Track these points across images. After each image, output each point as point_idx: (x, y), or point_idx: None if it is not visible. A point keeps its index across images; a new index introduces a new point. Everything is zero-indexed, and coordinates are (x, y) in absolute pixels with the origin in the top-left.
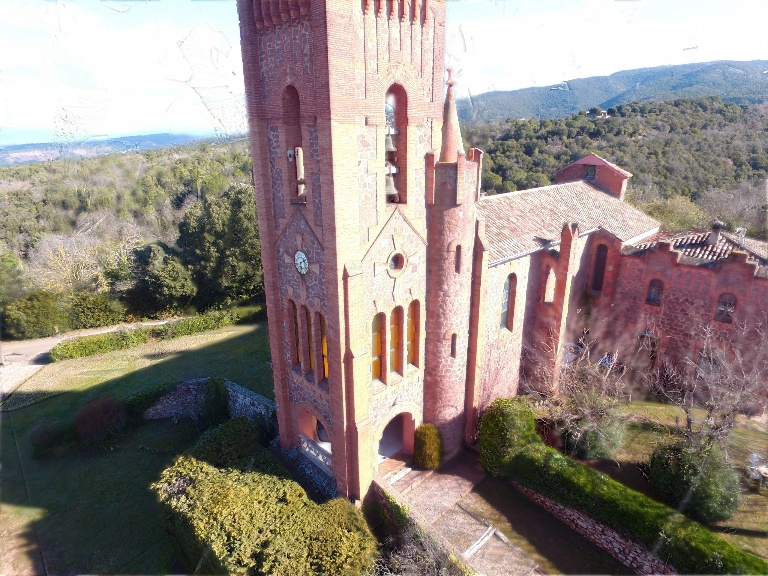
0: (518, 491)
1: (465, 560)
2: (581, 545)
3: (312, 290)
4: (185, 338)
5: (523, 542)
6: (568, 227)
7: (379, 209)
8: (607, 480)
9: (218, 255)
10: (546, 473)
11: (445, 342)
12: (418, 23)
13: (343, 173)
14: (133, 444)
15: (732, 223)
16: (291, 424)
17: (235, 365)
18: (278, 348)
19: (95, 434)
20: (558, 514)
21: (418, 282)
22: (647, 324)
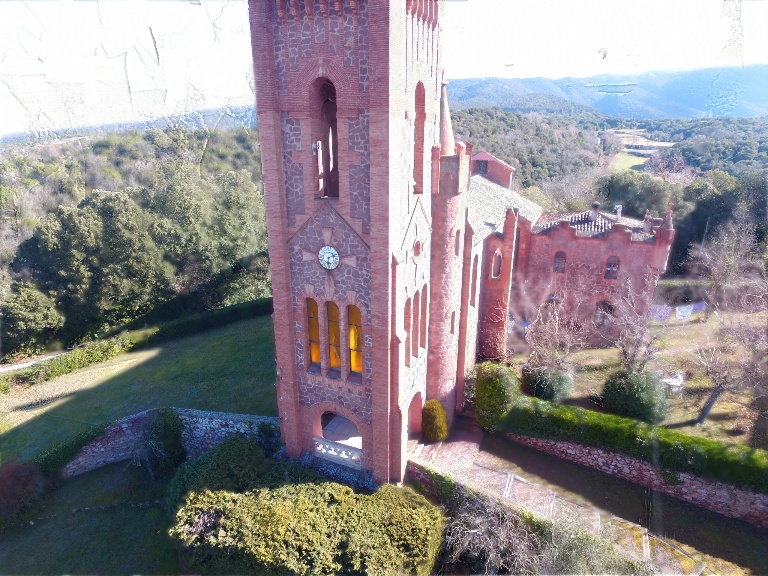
0: (512, 441)
1: (514, 502)
2: (574, 468)
3: (343, 284)
4: (65, 378)
5: (536, 479)
6: (512, 211)
7: (410, 199)
8: (584, 411)
9: (91, 275)
10: (538, 418)
11: (446, 320)
12: (431, 26)
13: (394, 164)
14: (62, 510)
15: (575, 206)
16: (301, 430)
17: (163, 393)
18: (290, 352)
19: (6, 510)
20: (549, 450)
21: (426, 267)
22: (555, 289)
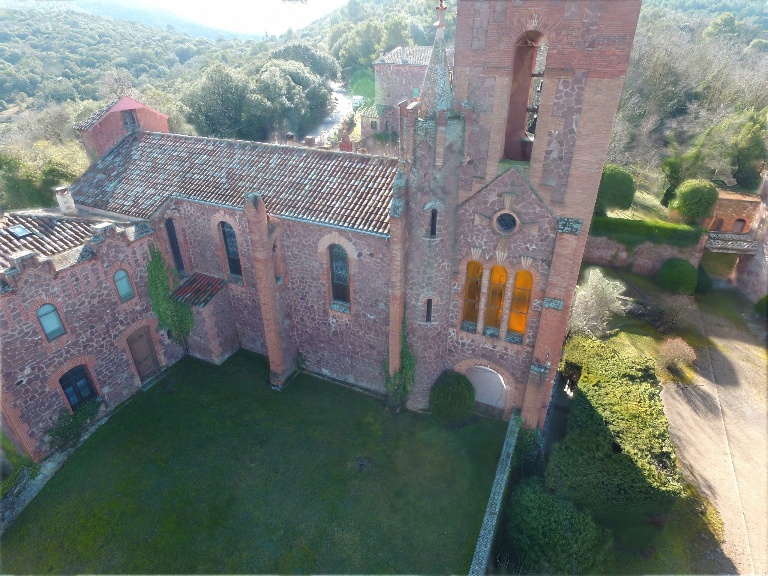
0: None
1: None
2: None
3: None
4: None
5: None
6: None
7: None
8: None
9: None
10: None
11: None
12: None
13: None
14: None
15: None
16: None
17: None
18: None
19: None
20: None
21: None
22: None
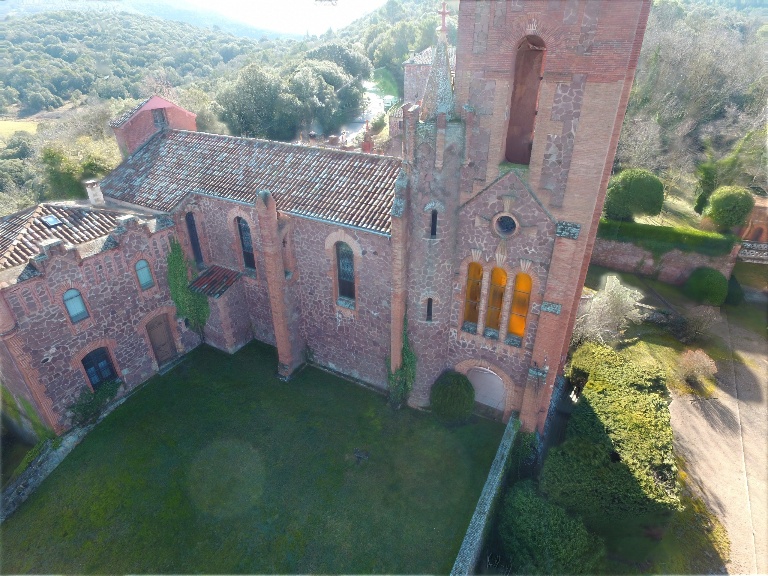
0: None
1: None
2: None
3: None
4: None
5: None
6: None
7: None
8: None
9: None
10: None
11: None
12: None
13: None
14: None
15: None
16: None
17: None
18: None
19: None
20: None
21: None
22: None
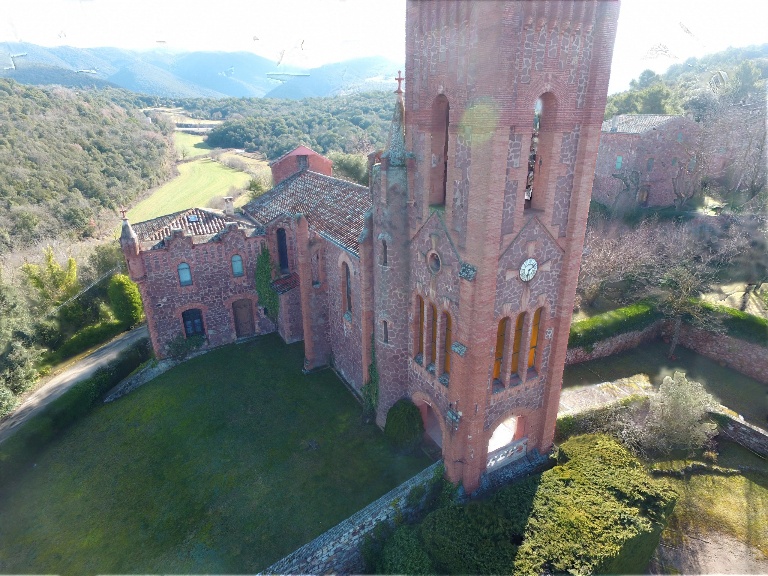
0: None
1: (596, 405)
2: None
3: (536, 291)
4: None
5: None
6: None
7: None
8: None
9: None
10: None
11: None
12: None
13: None
14: None
15: None
16: None
17: None
18: None
19: None
20: None
21: None
22: None
